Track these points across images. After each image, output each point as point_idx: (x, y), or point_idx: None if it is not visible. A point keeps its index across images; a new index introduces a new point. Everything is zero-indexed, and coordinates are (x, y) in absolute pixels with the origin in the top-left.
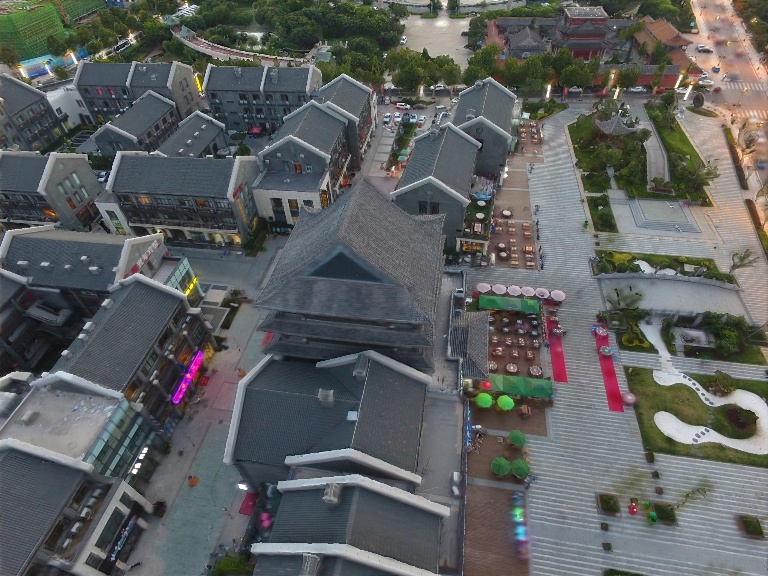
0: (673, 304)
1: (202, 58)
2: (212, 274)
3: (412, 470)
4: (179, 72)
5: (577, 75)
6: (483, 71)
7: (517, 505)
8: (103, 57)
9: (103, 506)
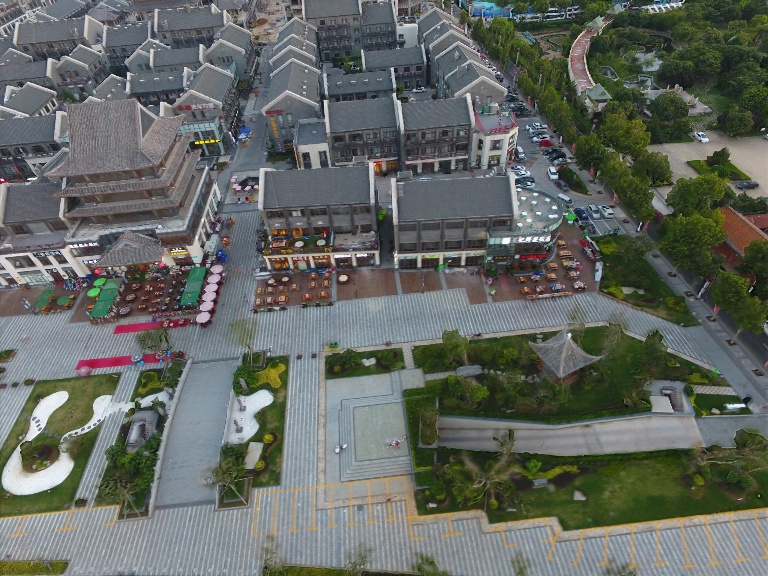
0: (187, 415)
1: (567, 49)
2: (247, 152)
3: (6, 220)
4: (452, 40)
5: (729, 293)
6: (649, 196)
7: (26, 310)
8: (526, 19)
9: (49, 155)
